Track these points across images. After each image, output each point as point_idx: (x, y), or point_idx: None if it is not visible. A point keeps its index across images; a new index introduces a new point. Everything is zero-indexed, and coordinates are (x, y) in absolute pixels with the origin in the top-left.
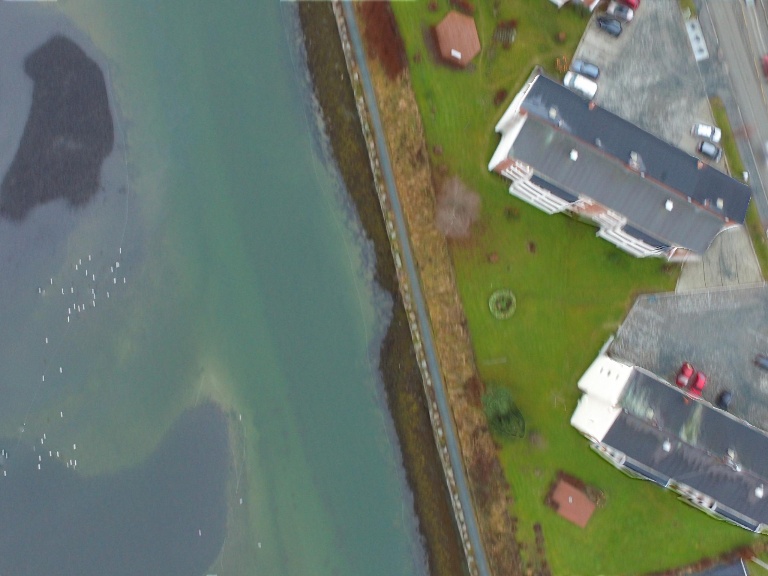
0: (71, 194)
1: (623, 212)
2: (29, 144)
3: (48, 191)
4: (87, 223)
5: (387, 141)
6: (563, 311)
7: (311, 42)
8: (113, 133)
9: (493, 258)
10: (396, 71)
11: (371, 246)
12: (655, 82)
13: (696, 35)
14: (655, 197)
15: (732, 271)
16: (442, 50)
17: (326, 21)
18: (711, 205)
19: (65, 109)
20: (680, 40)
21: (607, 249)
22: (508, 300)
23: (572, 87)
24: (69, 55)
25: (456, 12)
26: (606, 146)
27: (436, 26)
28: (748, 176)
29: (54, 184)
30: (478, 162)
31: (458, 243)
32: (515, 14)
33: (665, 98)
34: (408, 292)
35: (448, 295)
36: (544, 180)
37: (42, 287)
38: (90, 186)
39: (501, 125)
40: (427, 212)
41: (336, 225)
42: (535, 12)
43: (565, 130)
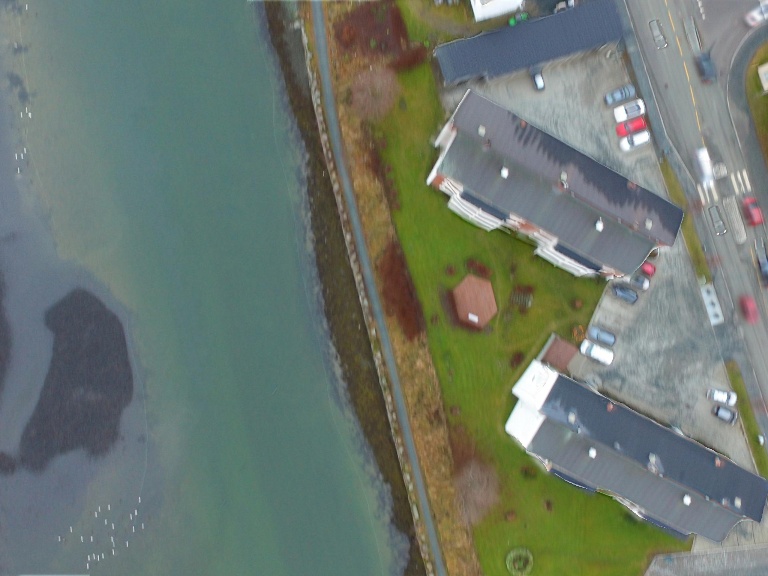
0: (91, 444)
1: (641, 503)
2: (49, 396)
3: (68, 442)
4: (106, 472)
5: (404, 395)
6: (580, 568)
7: (328, 291)
8: (132, 383)
9: (510, 517)
10: (414, 333)
11: (388, 489)
12: (671, 346)
13: (711, 301)
14: (673, 492)
15: (748, 530)
16: (459, 313)
17: (343, 272)
18: (729, 504)
19: (85, 361)
20: (695, 305)
21: (624, 511)
22: (525, 559)
23: (589, 356)
24: (89, 308)
25: (473, 275)
26: (625, 449)
27: (453, 290)
28: (764, 440)
29: (74, 435)
30: (495, 422)
31: (475, 502)
32: (532, 280)
33: (681, 361)
34: (425, 543)
35: (465, 551)
36: (563, 473)
37: (62, 535)
38: (109, 436)
39: (518, 390)
40: (444, 469)
41: (353, 468)
42: (552, 279)
43: (584, 433)
